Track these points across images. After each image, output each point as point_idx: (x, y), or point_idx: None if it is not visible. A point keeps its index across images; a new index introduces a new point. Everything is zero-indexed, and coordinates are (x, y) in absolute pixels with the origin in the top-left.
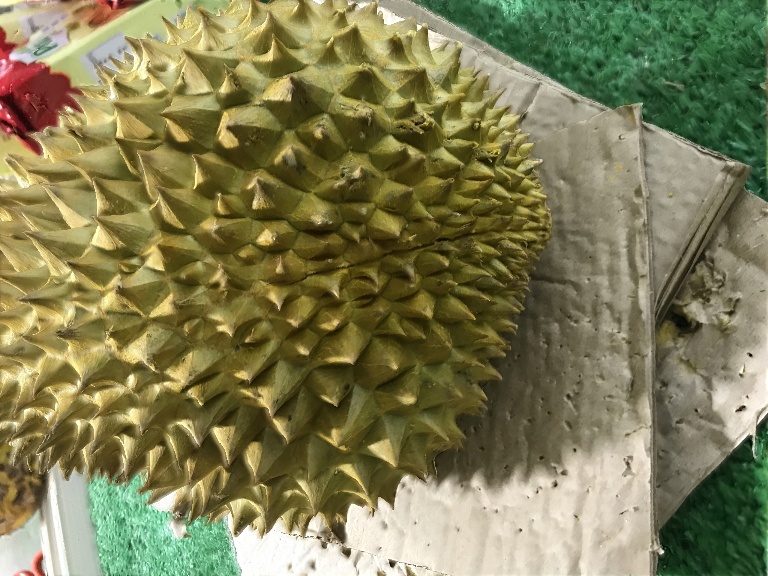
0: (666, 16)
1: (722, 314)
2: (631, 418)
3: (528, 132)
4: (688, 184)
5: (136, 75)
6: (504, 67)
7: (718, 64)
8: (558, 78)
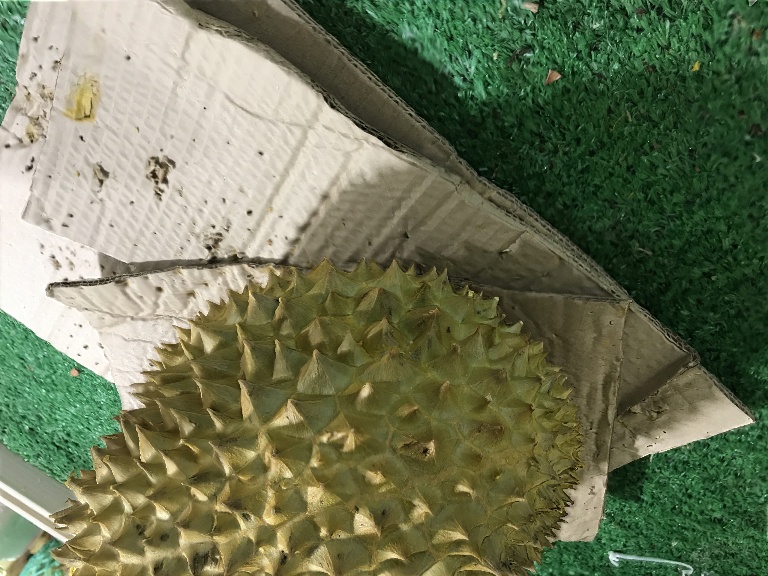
0: (648, 185)
1: (653, 413)
2: (595, 469)
3: (511, 268)
4: (653, 356)
5: (310, 571)
6: (485, 203)
7: (684, 249)
8: (529, 196)
